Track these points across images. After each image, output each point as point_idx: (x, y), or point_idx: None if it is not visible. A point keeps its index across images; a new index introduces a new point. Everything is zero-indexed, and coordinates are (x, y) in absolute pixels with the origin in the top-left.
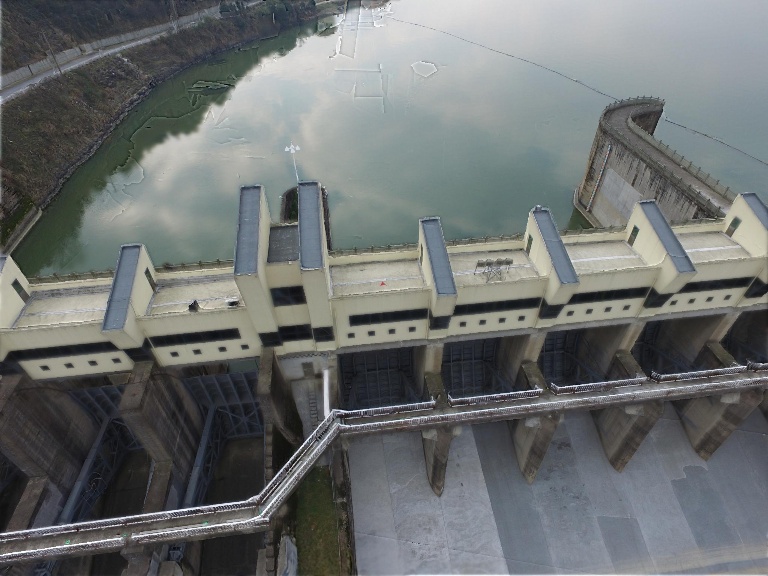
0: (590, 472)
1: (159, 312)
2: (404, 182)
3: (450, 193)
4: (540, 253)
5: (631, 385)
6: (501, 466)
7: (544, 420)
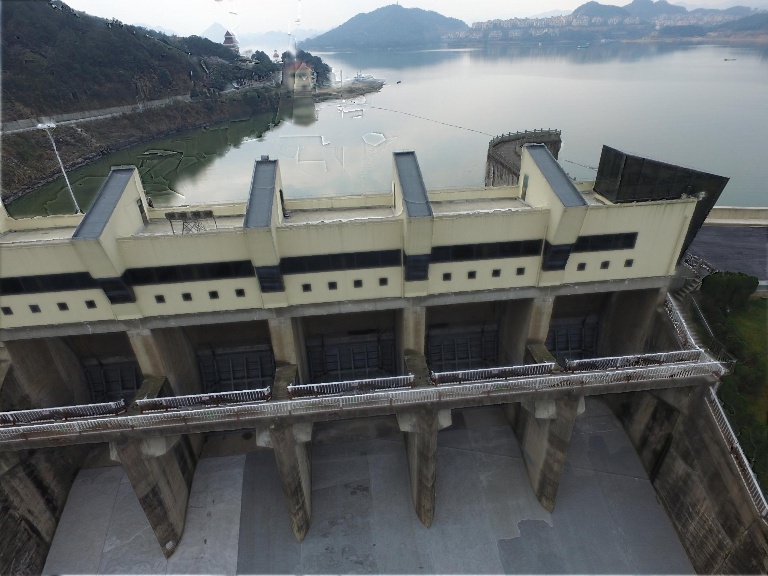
0: (387, 527)
1: None
2: None
3: None
4: None
5: (397, 387)
6: (267, 516)
7: (270, 433)
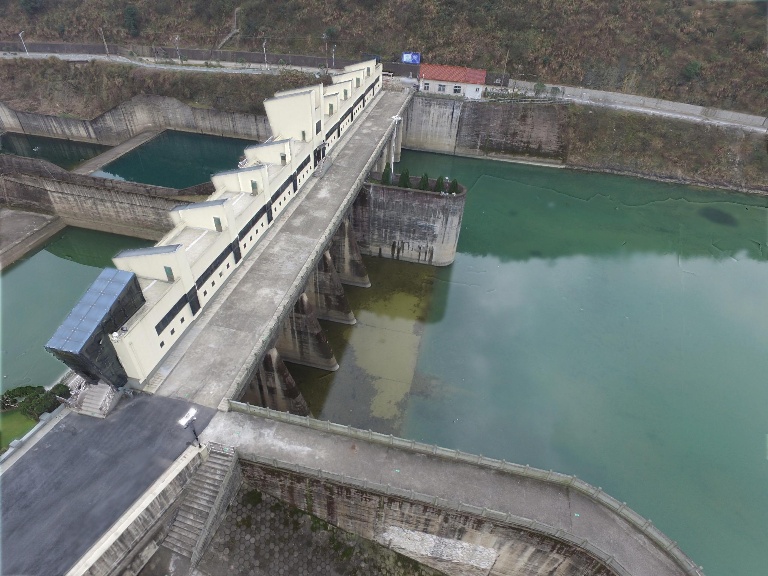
0: None
1: None
2: (619, 362)
3: (586, 399)
4: None
5: None
6: None
7: None
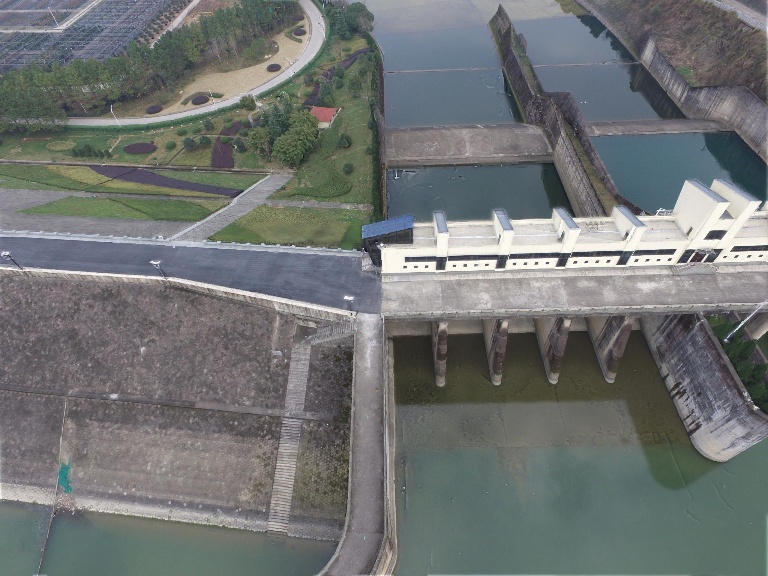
0: None
1: (765, 223)
2: None
3: None
4: None
5: None
6: None
7: None
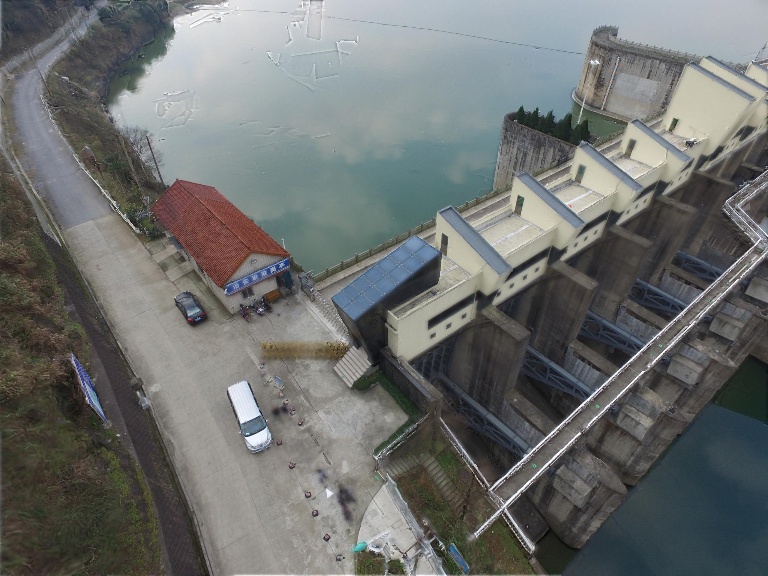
0: (763, 224)
1: None
2: (464, 124)
3: None
4: (767, 84)
5: None
6: None
7: None
